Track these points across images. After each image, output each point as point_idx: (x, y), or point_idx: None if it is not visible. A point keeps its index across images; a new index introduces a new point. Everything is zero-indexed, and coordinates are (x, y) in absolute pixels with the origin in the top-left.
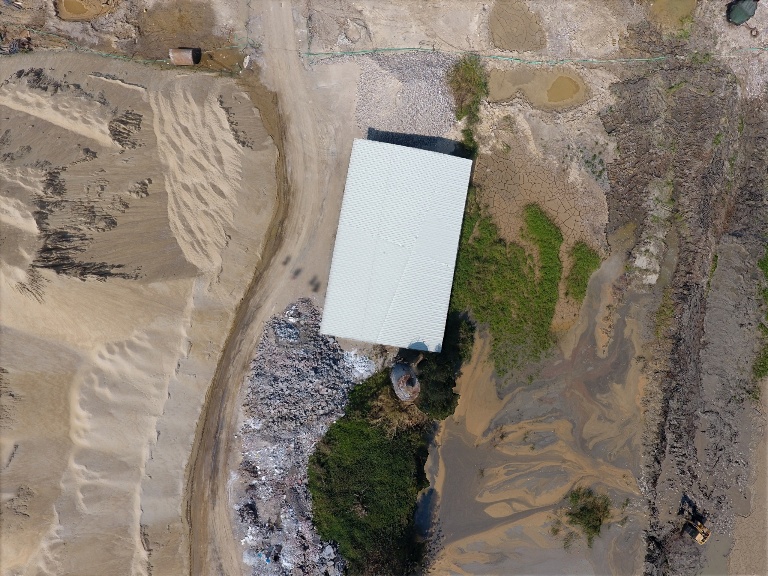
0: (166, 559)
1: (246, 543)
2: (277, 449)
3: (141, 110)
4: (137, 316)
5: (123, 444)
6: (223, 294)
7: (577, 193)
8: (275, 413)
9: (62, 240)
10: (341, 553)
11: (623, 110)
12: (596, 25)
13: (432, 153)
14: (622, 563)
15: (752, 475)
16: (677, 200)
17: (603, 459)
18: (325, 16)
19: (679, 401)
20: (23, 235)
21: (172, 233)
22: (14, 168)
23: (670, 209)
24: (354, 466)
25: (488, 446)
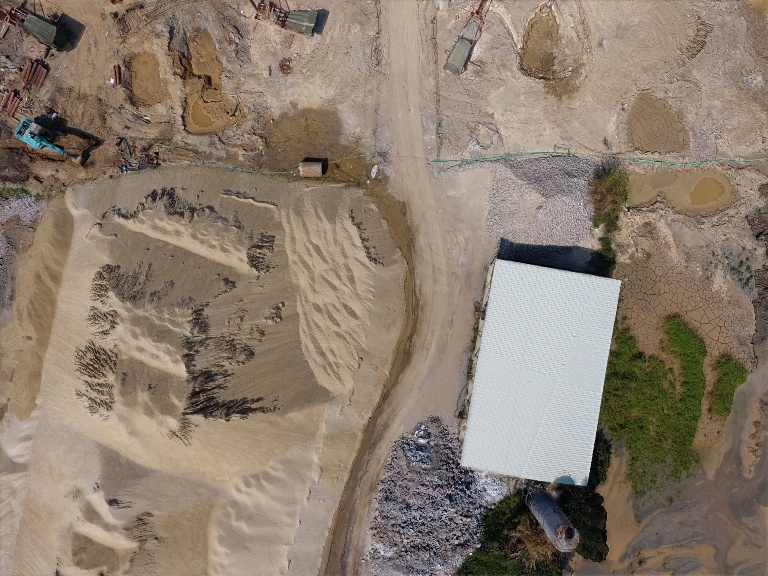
0: None
1: None
2: None
3: (274, 230)
4: (273, 448)
5: (256, 575)
6: (352, 415)
7: (722, 302)
8: (408, 542)
9: (208, 381)
10: None
11: None
12: (744, 122)
13: (580, 275)
14: None
15: None
16: None
17: None
18: (455, 121)
19: None
20: (172, 380)
21: (304, 356)
22: (162, 309)
23: None
24: None
25: (625, 572)
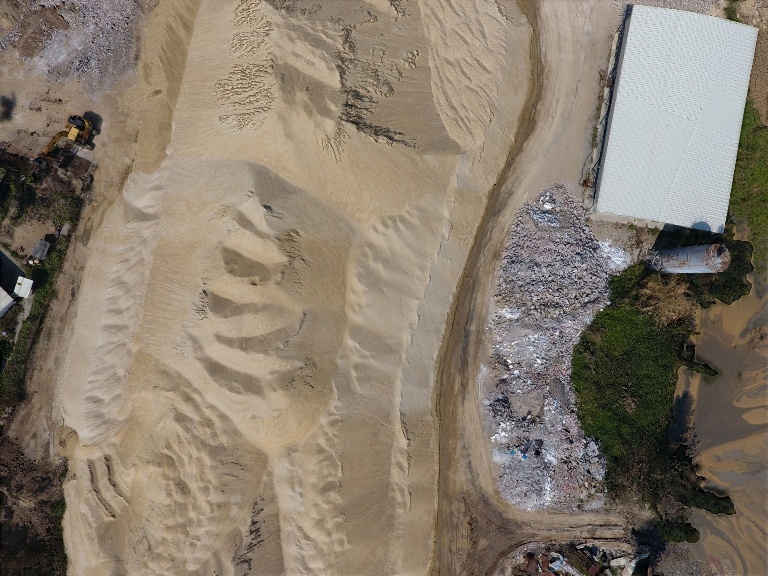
0: (421, 451)
1: (496, 440)
2: (537, 339)
3: None
4: (411, 189)
5: (388, 326)
6: (480, 176)
7: None
8: (538, 300)
9: (358, 98)
10: (603, 451)
11: None
12: None
13: (719, 19)
14: None
15: None
16: None
17: None
18: None
19: None
20: (326, 89)
21: (436, 109)
22: (314, 21)
23: None
24: (621, 357)
25: (746, 347)
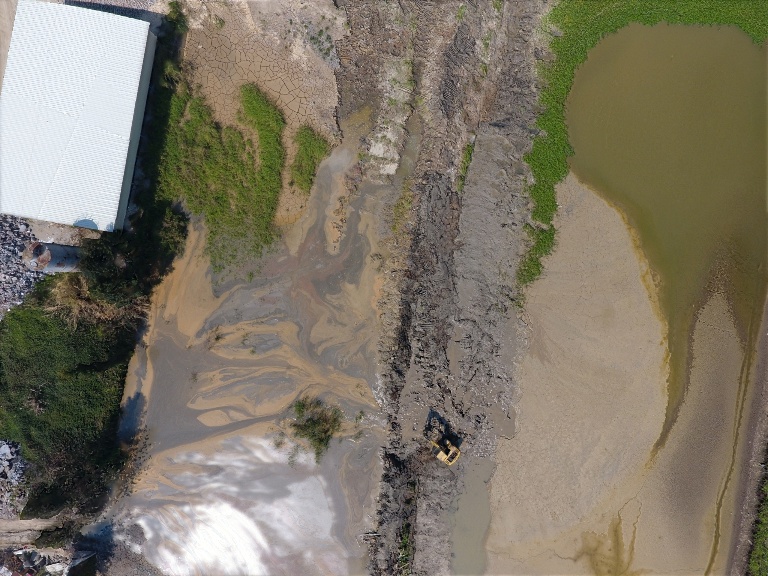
0: None
1: None
2: None
3: None
4: None
5: None
6: None
7: (302, 72)
8: None
9: None
10: (21, 454)
11: None
12: None
13: (101, 13)
14: (355, 482)
15: (517, 392)
16: (420, 82)
17: (333, 366)
18: None
19: (423, 305)
20: None
21: None
22: None
23: (409, 91)
24: (31, 359)
25: (202, 348)
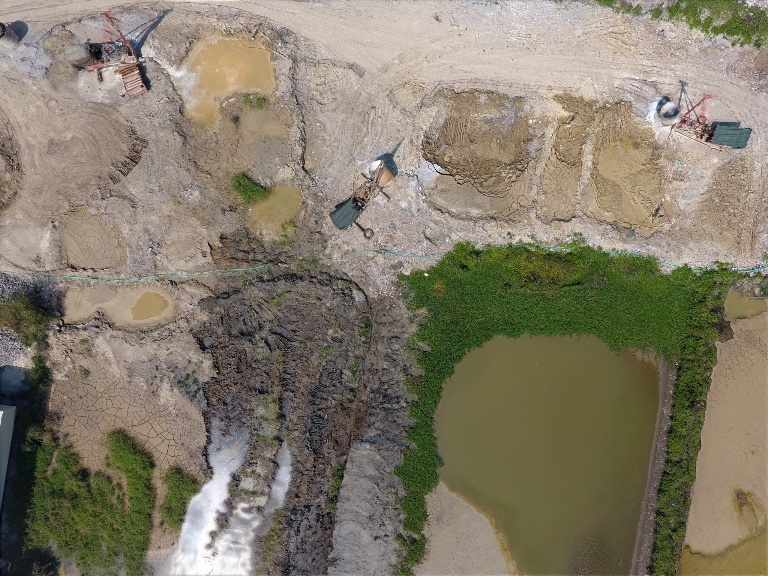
0: None
1: None
2: None
3: None
4: None
5: None
6: None
7: (170, 415)
8: None
9: None
10: None
11: (221, 324)
12: (183, 236)
13: None
14: None
15: None
16: (288, 415)
17: None
18: None
19: None
20: None
21: None
22: None
23: (277, 427)
24: None
25: None
